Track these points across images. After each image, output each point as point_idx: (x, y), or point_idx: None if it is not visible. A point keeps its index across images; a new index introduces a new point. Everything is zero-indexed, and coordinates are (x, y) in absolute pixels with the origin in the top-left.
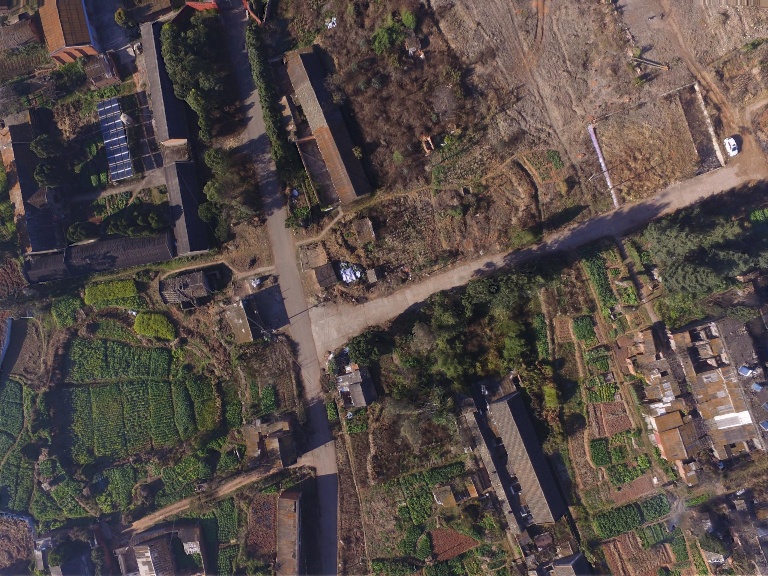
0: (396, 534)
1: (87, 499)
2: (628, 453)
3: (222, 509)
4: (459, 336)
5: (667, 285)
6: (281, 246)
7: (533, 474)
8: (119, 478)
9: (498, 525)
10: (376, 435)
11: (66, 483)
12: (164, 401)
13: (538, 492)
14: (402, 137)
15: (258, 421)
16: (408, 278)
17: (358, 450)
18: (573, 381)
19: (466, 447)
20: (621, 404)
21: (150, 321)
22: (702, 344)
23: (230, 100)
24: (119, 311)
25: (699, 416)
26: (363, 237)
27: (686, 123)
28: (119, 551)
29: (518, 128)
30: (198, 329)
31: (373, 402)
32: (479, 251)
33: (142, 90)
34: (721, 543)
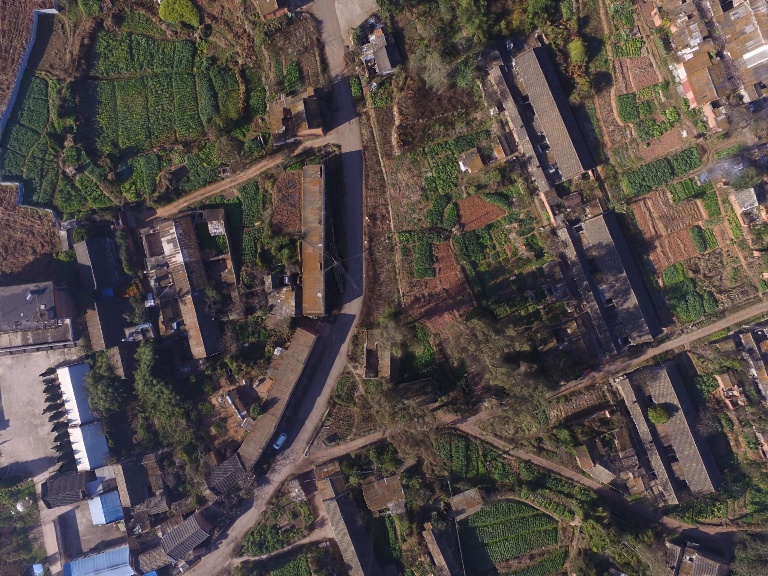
0: (422, 205)
1: (112, 184)
2: (656, 107)
3: (246, 192)
4: None
5: None
6: None
7: (561, 123)
8: (144, 165)
9: (526, 184)
10: (401, 105)
11: (91, 169)
12: (188, 93)
13: (566, 142)
14: None
15: (283, 95)
16: None
17: (383, 123)
18: (598, 39)
19: (492, 108)
20: (648, 59)
21: (175, 5)
22: None
23: None
24: (144, 0)
25: (728, 56)
26: None
27: None
28: (144, 231)
29: None
30: (222, 16)
31: (398, 65)
32: None
33: None
34: (755, 169)
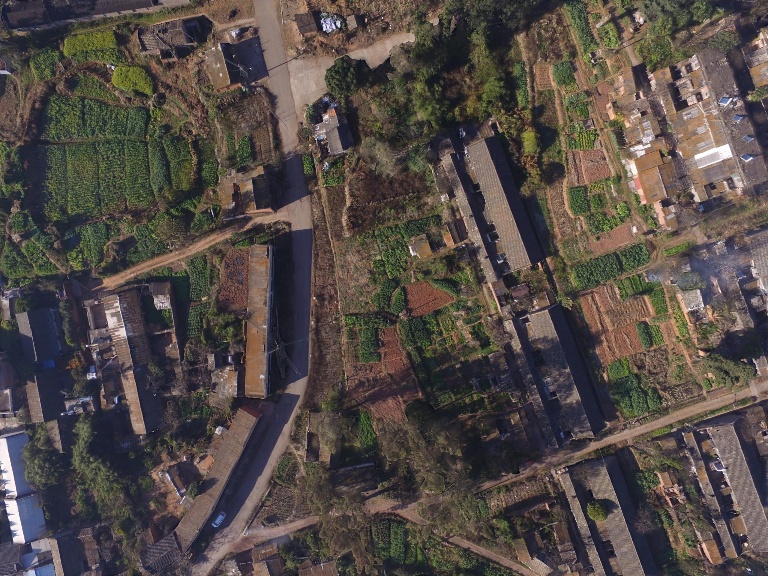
0: (370, 288)
1: (58, 253)
2: (607, 201)
3: (194, 266)
4: (438, 81)
5: (647, 13)
6: None
7: (510, 215)
8: (91, 234)
9: (474, 273)
10: (352, 186)
11: (37, 236)
12: (140, 161)
13: (515, 234)
14: None
15: (233, 171)
16: (388, 28)
17: (334, 203)
18: (552, 129)
19: (443, 195)
20: (601, 152)
21: (128, 73)
22: (683, 82)
23: None
24: (98, 66)
25: (679, 156)
26: None
27: None
28: (88, 303)
29: None
30: (176, 85)
31: (350, 147)
32: None
33: None
34: (700, 275)
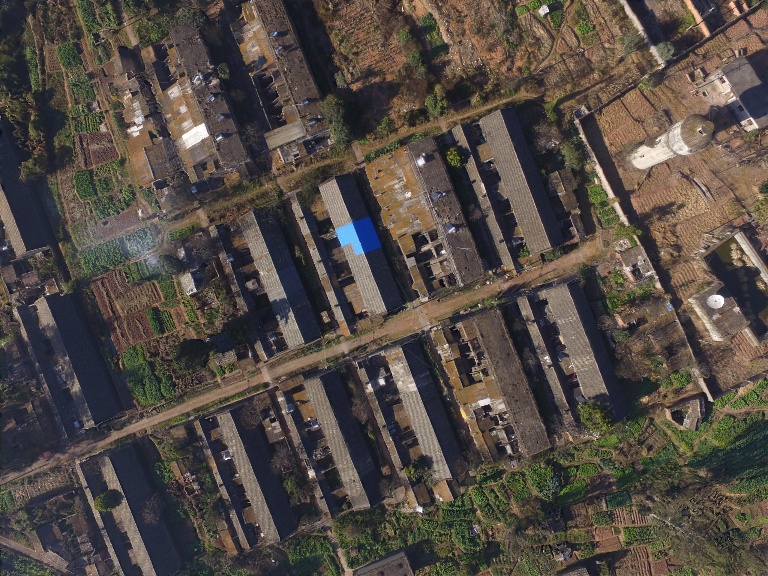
0: None
1: None
2: (114, 185)
3: None
4: None
5: None
6: None
7: (5, 200)
8: None
9: None
10: None
11: None
12: None
13: (11, 220)
14: None
15: None
16: None
17: None
18: (62, 112)
19: None
20: (108, 134)
21: None
22: (170, 61)
23: None
24: None
25: (168, 136)
26: None
27: None
28: None
29: None
30: None
31: None
32: None
33: None
34: (168, 258)
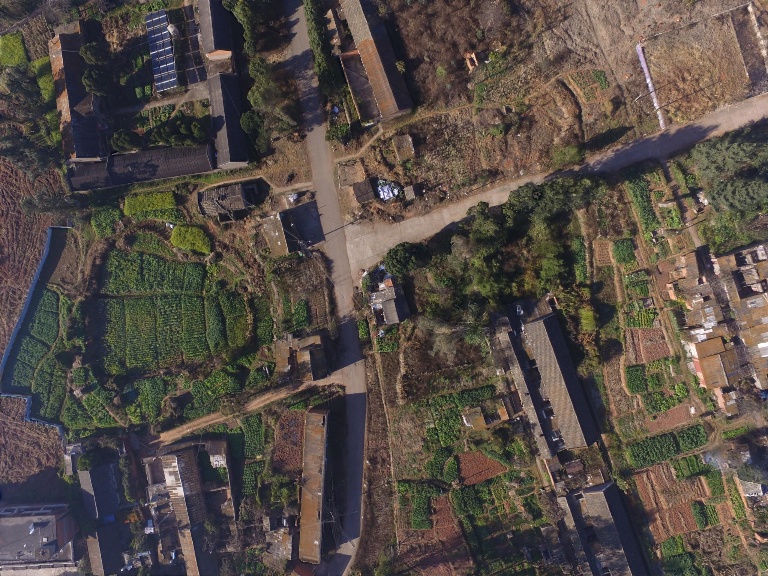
0: (423, 456)
1: (117, 408)
2: (665, 381)
3: (249, 424)
4: (496, 255)
5: (714, 204)
6: (319, 162)
7: (567, 396)
8: (149, 389)
9: (528, 449)
10: (407, 354)
11: (98, 391)
12: (196, 316)
13: (571, 415)
14: (446, 53)
15: (290, 336)
16: (446, 197)
17: (388, 369)
18: (611, 306)
19: (498, 369)
20: (660, 331)
21: (187, 233)
22: (748, 269)
23: (275, 15)
24: (157, 224)
25: (742, 343)
26: (403, 153)
27: (738, 45)
28: (147, 460)
29: (564, 47)
30: (233, 244)
31: (406, 319)
32: (519, 171)
33: (189, 4)
34: (762, 472)
